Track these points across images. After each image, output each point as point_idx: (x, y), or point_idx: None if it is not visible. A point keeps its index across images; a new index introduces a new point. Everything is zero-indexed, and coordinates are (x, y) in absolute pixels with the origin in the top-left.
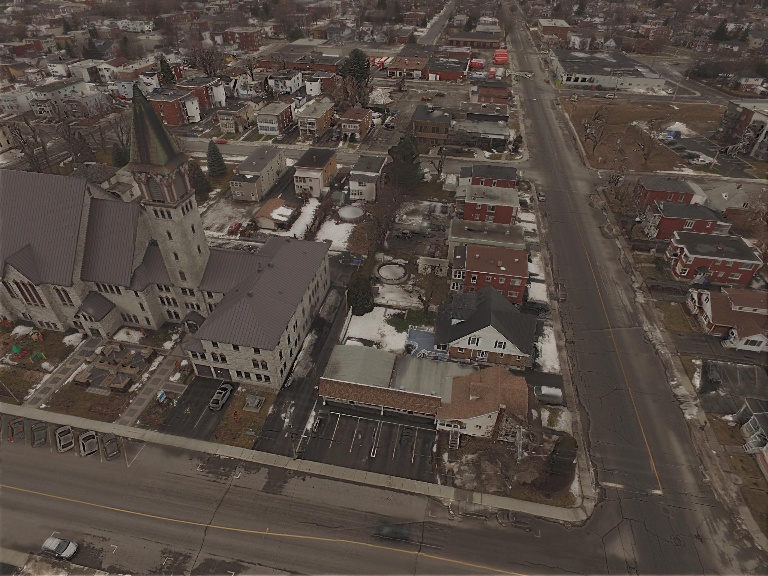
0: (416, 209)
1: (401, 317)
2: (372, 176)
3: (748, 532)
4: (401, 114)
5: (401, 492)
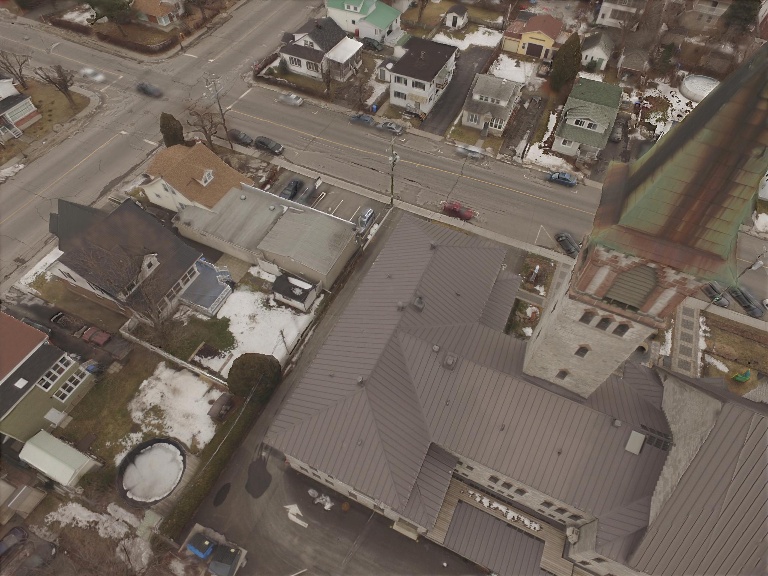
0: None
1: (207, 347)
2: None
3: (96, 108)
4: None
5: (312, 169)
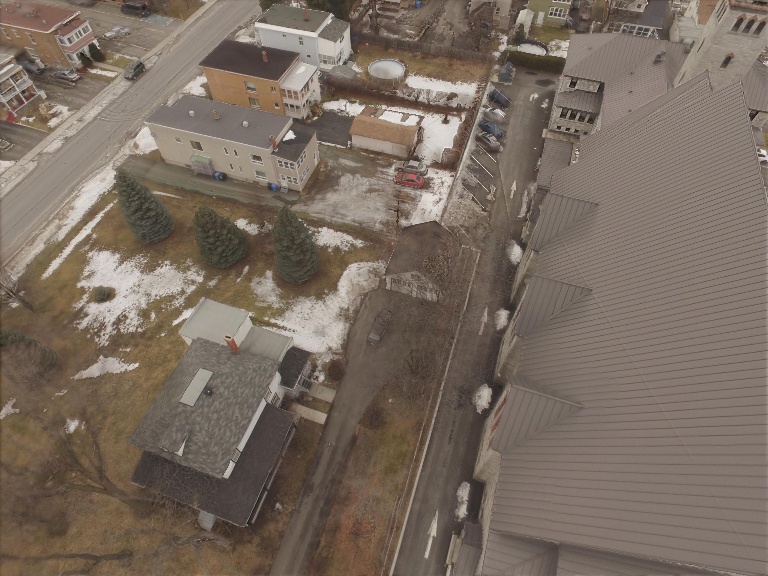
0: (383, 26)
1: None
2: (332, 22)
3: None
4: (1, 2)
5: None
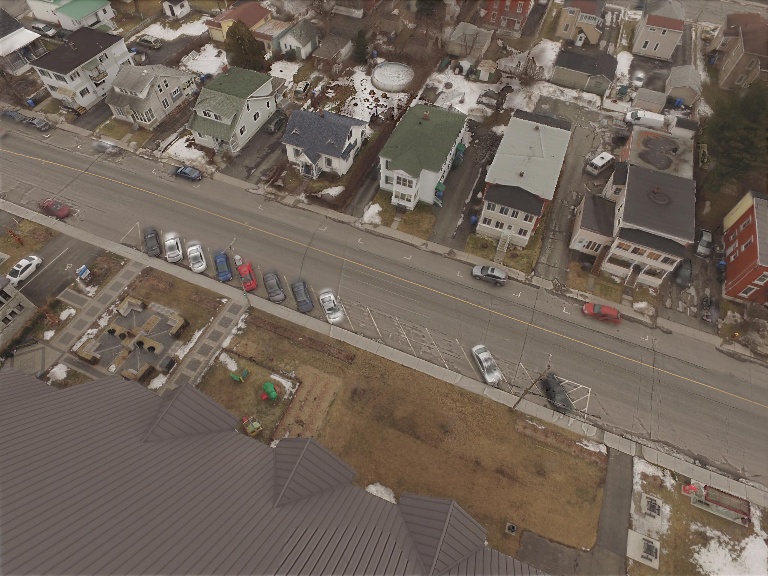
0: None
1: None
2: None
3: None
4: None
5: None
